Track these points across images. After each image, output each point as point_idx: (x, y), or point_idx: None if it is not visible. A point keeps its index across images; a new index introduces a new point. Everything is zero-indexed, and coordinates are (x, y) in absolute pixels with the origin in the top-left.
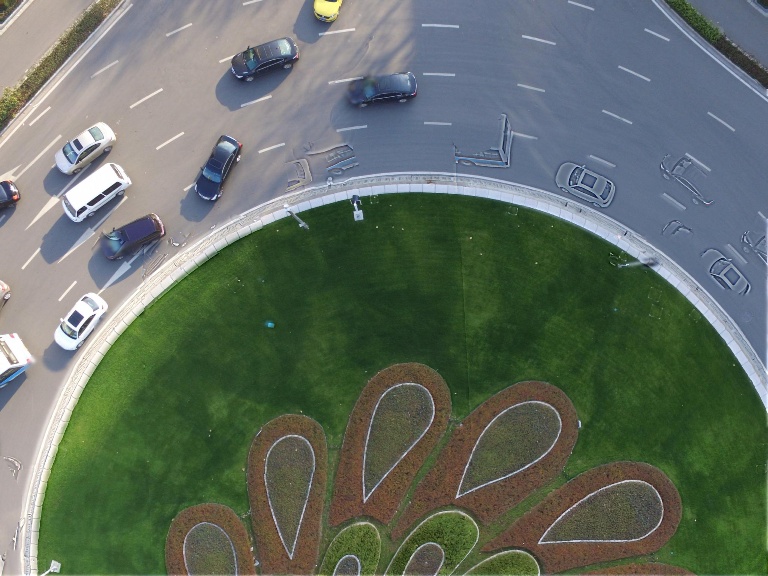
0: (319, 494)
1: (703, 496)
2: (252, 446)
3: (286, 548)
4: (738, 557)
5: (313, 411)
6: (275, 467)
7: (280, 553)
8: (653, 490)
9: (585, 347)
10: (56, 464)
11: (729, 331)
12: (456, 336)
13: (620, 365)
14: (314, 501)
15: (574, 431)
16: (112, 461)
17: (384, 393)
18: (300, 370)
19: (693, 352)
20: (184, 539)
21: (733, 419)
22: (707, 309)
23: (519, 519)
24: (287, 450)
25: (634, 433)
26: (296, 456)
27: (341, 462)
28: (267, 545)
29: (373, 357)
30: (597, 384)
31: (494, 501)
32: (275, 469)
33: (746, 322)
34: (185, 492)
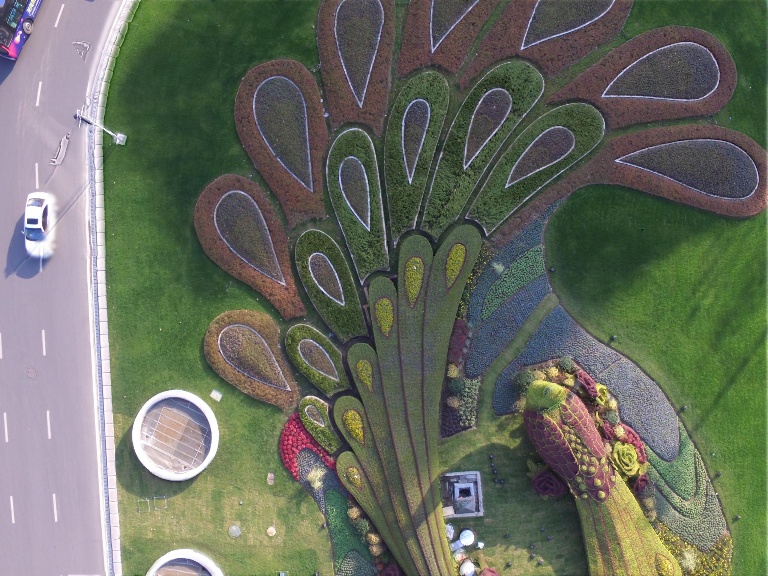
0: (388, 44)
1: (756, 65)
2: (322, 4)
3: (356, 97)
4: None
5: None
6: (345, 19)
7: (350, 100)
8: (708, 53)
9: None
10: (125, 42)
11: None
12: None
13: None
14: (383, 50)
15: None
16: (183, 29)
17: None
18: None
19: None
20: (254, 93)
21: None
22: None
23: (582, 73)
24: (357, 3)
25: (687, 1)
26: (366, 8)
27: (409, 15)
28: (338, 92)
29: None
30: None
31: (558, 51)
32: (345, 21)
33: None
34: (255, 52)
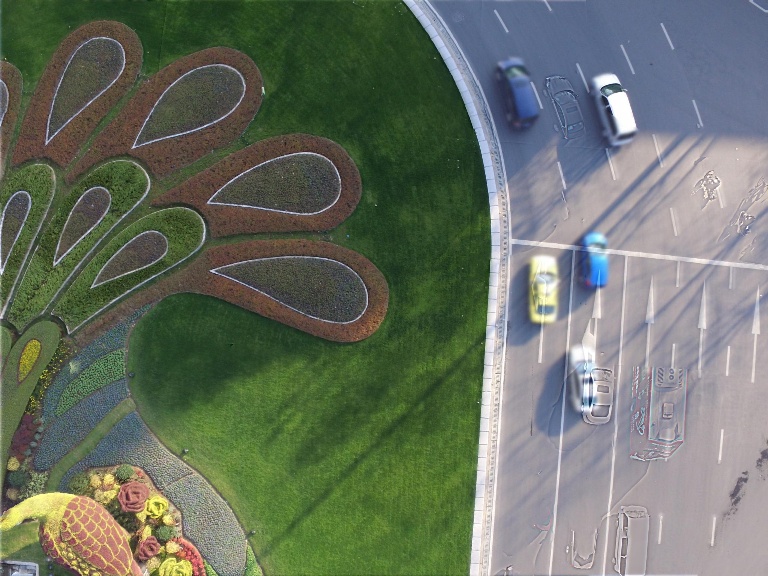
0: (6, 133)
1: (386, 181)
2: None
3: None
4: (420, 252)
5: (16, 59)
6: None
7: None
8: (332, 166)
9: (282, 23)
10: None
11: (437, 29)
12: (158, 1)
13: (315, 43)
14: (0, 138)
15: (256, 97)
16: None
17: (81, 45)
18: (12, 23)
19: (392, 40)
20: None
21: (426, 108)
22: (414, 3)
23: (192, 177)
24: None
25: (319, 108)
26: None
27: (31, 105)
28: None
29: (78, 14)
30: (288, 58)
31: (167, 153)
32: None
33: (455, 22)
34: None
